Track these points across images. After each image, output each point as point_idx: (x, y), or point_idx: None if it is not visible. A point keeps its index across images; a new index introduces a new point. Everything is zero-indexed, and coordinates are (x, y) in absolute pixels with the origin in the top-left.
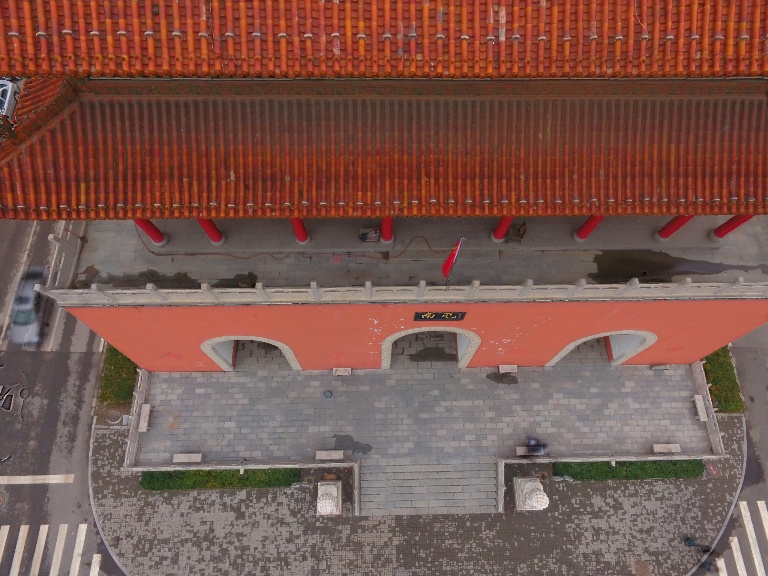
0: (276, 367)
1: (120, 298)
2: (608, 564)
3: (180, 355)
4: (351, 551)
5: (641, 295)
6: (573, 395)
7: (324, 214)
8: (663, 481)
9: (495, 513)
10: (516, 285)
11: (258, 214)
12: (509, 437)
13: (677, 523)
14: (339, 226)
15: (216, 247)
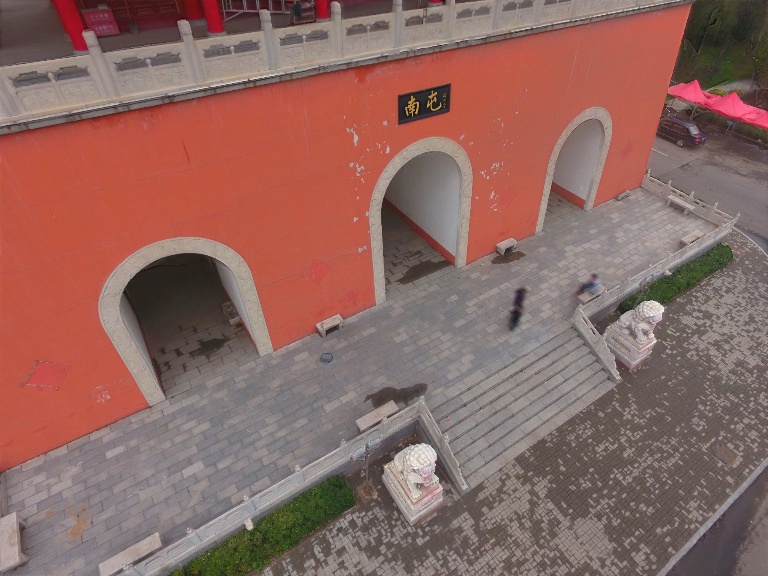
0: (232, 365)
1: None
2: (758, 367)
3: (60, 366)
4: (495, 546)
5: (589, 13)
6: (581, 242)
7: None
8: (714, 277)
9: (615, 386)
10: None
11: None
12: (561, 298)
13: (762, 301)
14: None
15: None
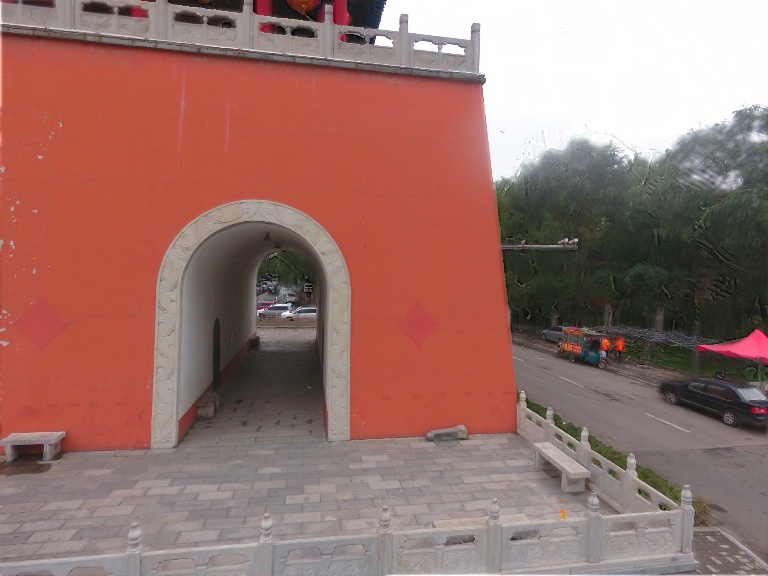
0: None
1: None
2: None
3: None
4: None
5: None
6: (202, 479)
7: None
8: None
9: None
10: None
11: None
12: None
13: None
14: None
15: None
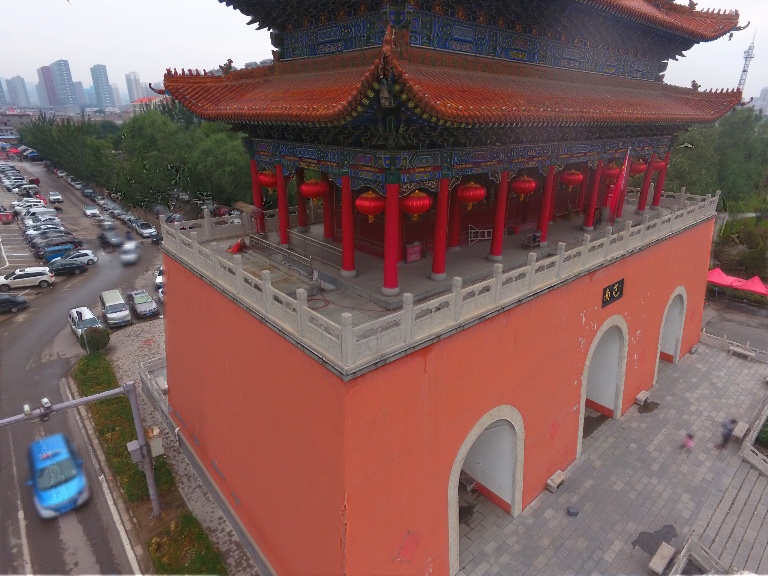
0: (495, 529)
1: (416, 332)
2: None
3: (417, 537)
4: None
5: None
6: (692, 389)
7: (585, 115)
8: None
9: None
10: (640, 225)
11: (559, 114)
12: (716, 437)
13: None
14: (503, 251)
15: (443, 281)
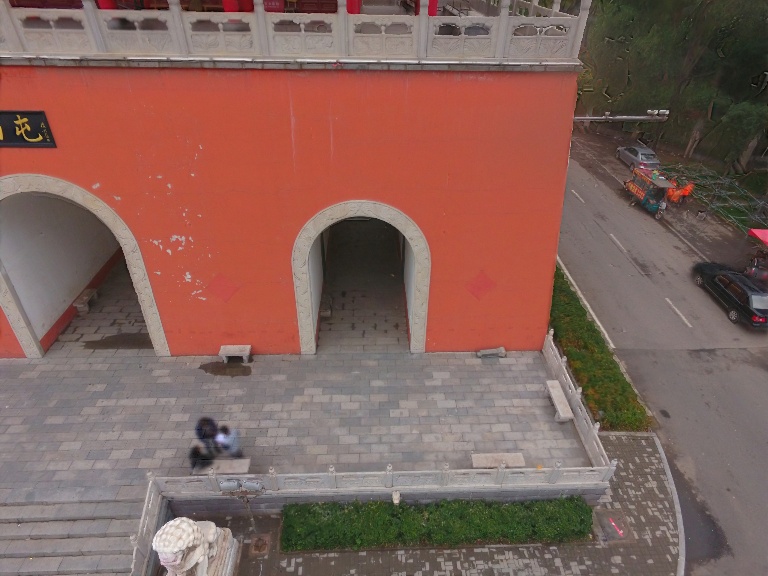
0: None
1: None
2: None
3: None
4: None
5: (300, 55)
6: (340, 390)
7: None
8: (515, 551)
9: None
10: (74, 9)
11: None
12: (198, 452)
13: None
14: None
15: None
